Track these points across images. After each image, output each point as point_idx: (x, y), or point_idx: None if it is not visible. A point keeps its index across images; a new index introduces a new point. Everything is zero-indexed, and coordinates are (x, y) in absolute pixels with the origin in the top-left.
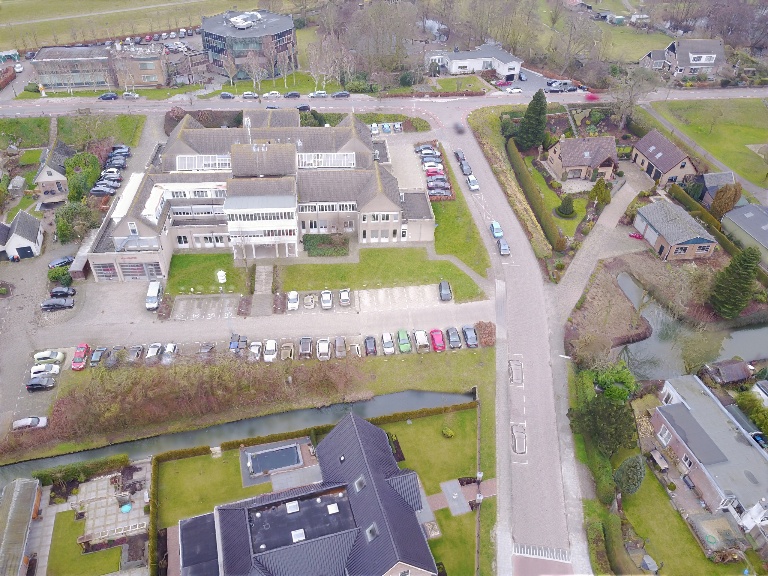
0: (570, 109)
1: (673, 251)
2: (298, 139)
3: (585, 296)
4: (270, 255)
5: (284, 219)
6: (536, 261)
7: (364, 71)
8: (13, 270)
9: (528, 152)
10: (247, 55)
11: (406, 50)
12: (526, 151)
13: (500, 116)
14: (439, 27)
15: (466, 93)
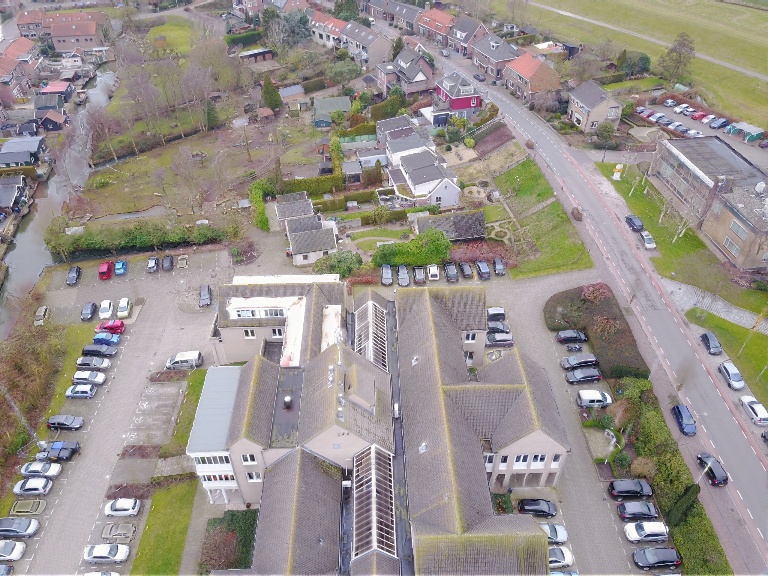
0: None
1: None
2: (428, 441)
3: None
4: None
5: None
6: None
7: None
8: (275, 257)
9: None
10: None
11: None
12: None
13: None
14: None
15: None
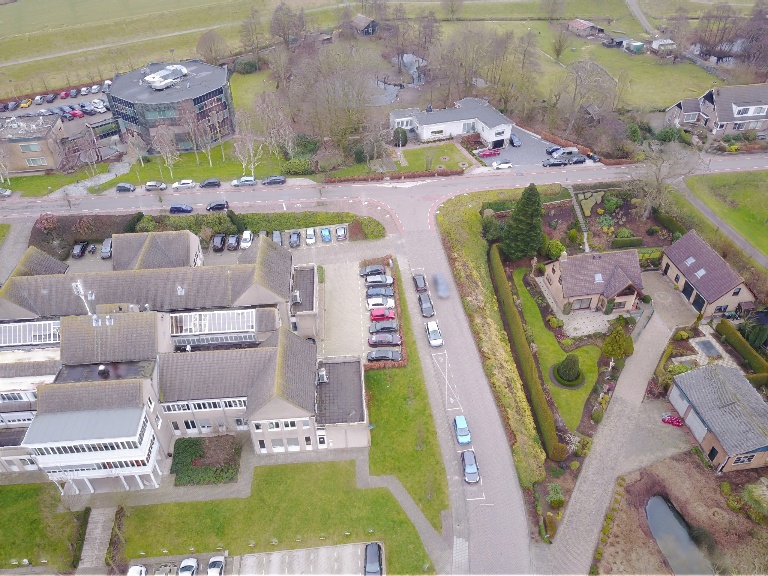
0: (576, 192)
1: (732, 461)
2: (178, 285)
3: (596, 570)
4: (117, 485)
5: (123, 449)
6: (519, 493)
7: (314, 137)
8: None
9: (518, 262)
10: (157, 129)
11: (362, 114)
12: (515, 260)
13: (481, 210)
14: (419, 65)
15: (438, 173)
